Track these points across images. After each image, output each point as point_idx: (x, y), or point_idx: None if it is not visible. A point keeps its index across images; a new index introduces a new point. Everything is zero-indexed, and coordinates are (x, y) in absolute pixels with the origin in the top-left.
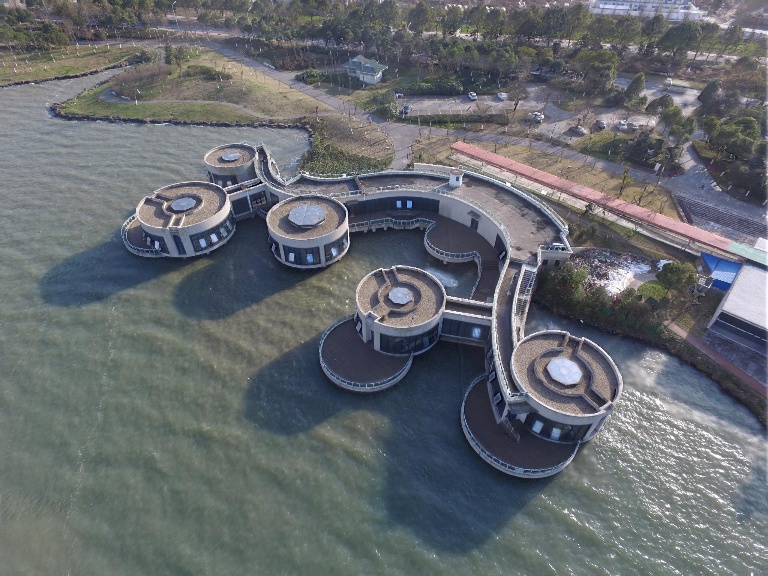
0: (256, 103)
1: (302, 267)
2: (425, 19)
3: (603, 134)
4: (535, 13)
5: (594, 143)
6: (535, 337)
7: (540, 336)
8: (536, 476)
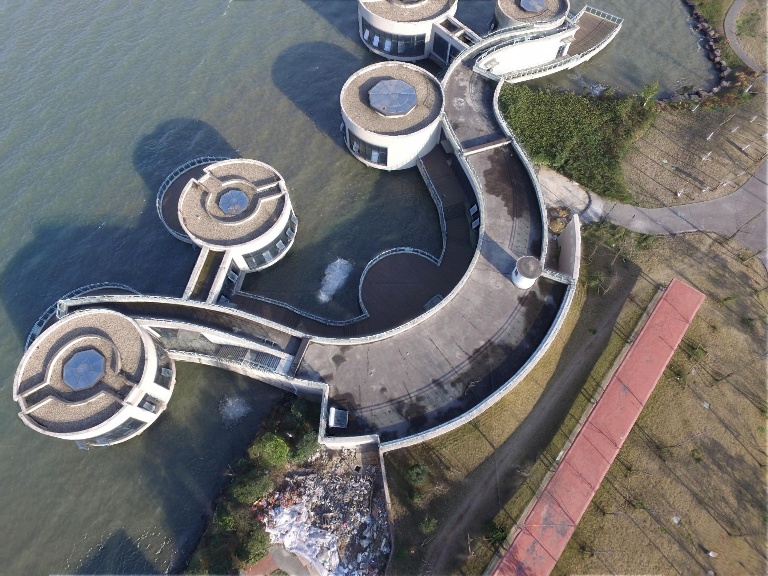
0: (767, 5)
1: None
2: None
3: None
4: None
5: None
6: None
7: None
8: None
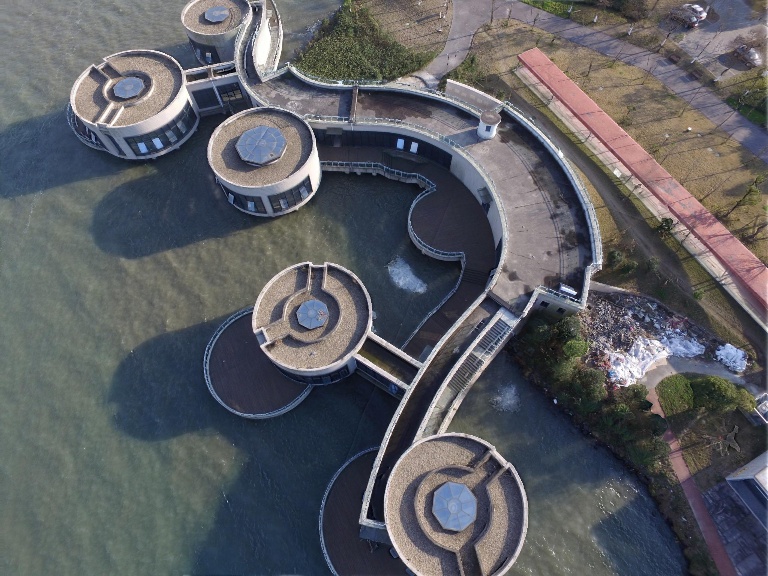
0: None
1: (245, 211)
2: None
3: None
4: None
5: (759, 88)
6: (448, 437)
7: (456, 438)
8: None
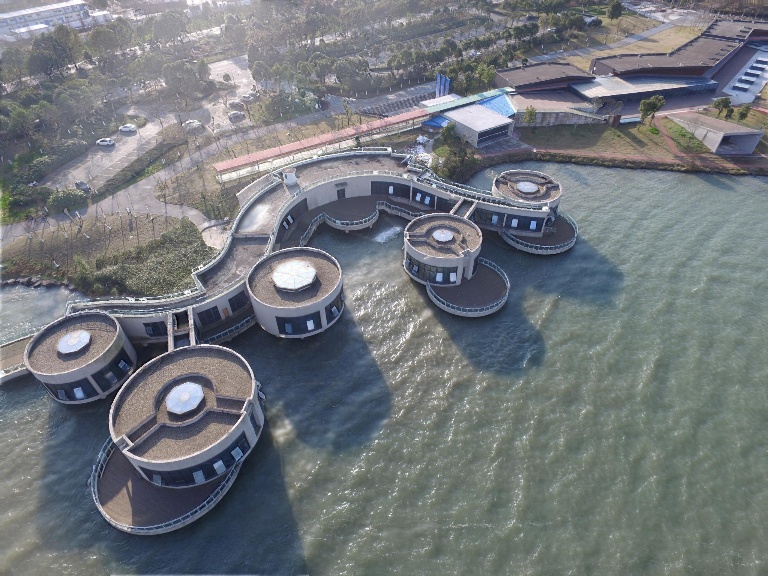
0: None
1: (340, 314)
2: None
3: None
4: None
5: (261, 116)
6: None
7: None
8: None
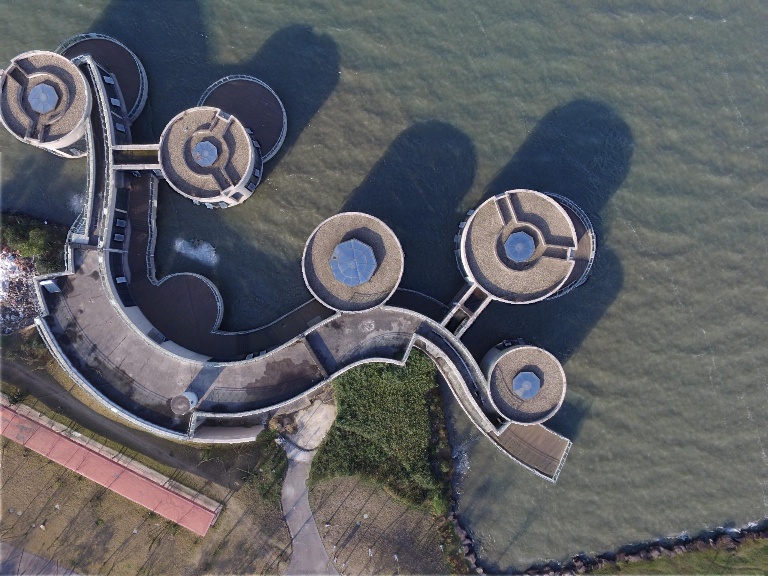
0: None
1: None
2: None
3: None
4: None
5: None
6: None
7: None
8: None
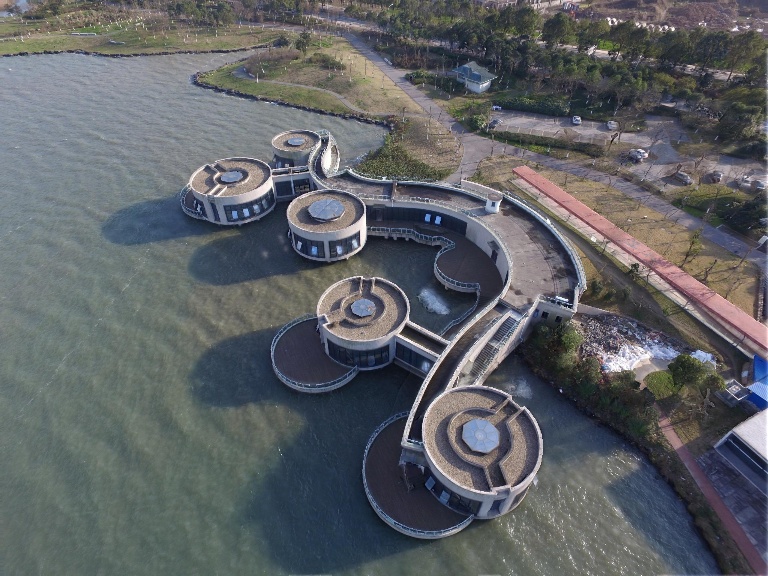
0: (356, 96)
1: (308, 257)
2: (561, 31)
3: (714, 188)
4: (698, 37)
5: (695, 196)
6: (473, 390)
7: (479, 390)
8: (407, 533)
